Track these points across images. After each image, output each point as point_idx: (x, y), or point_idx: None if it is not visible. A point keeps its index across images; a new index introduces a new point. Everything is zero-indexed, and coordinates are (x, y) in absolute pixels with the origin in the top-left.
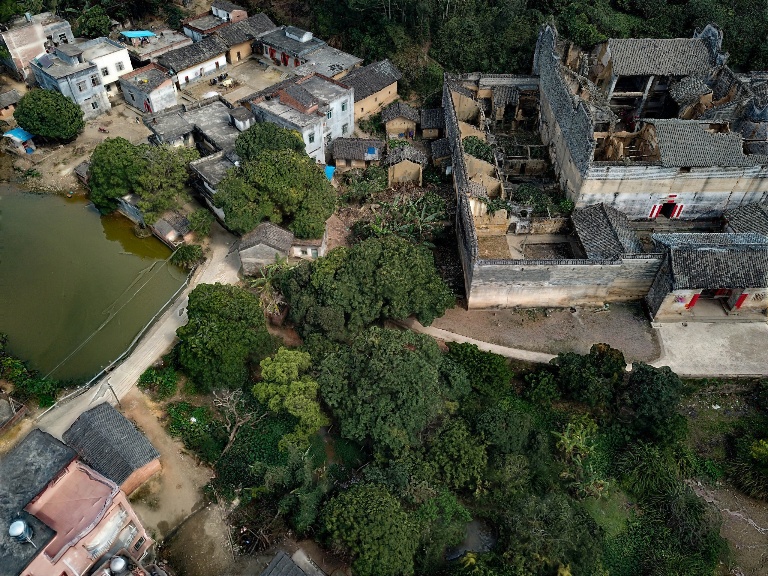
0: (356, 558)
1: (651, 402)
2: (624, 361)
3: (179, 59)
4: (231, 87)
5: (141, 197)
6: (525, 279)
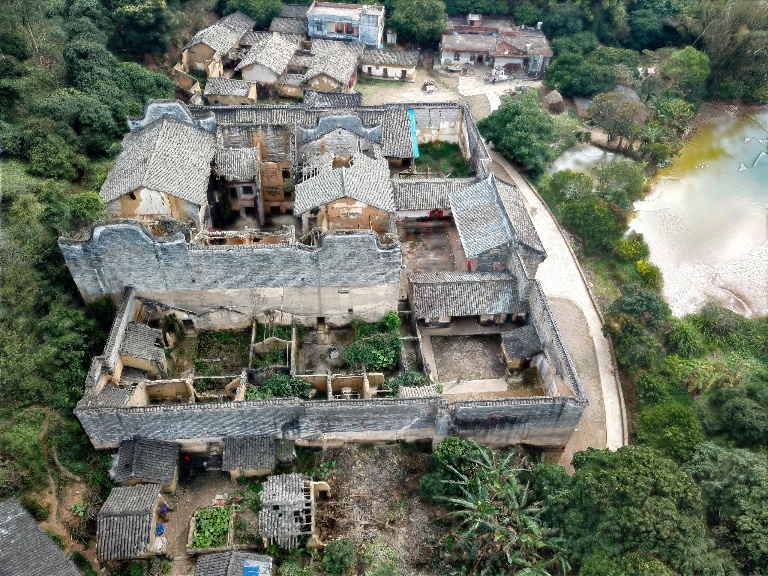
0: None
1: None
2: None
3: None
4: None
5: None
6: None
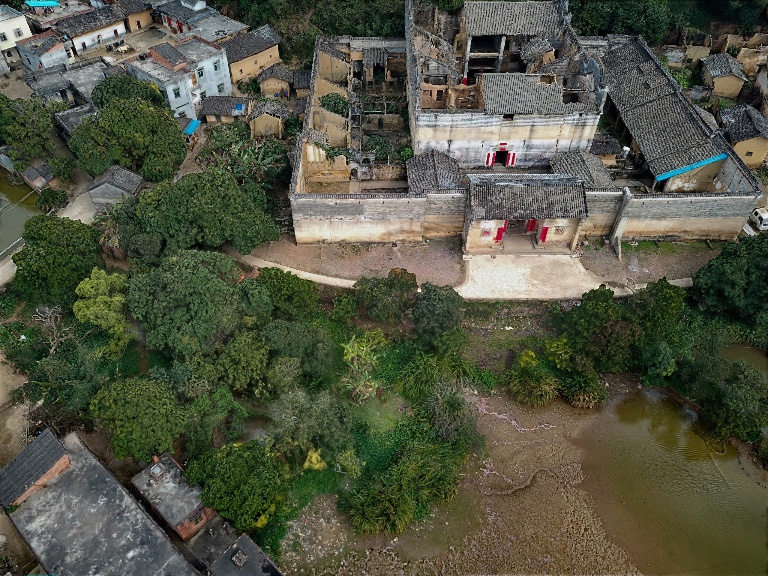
0: (113, 435)
1: (429, 316)
2: (414, 282)
3: (74, 26)
4: (126, 53)
5: (11, 146)
6: (341, 213)
